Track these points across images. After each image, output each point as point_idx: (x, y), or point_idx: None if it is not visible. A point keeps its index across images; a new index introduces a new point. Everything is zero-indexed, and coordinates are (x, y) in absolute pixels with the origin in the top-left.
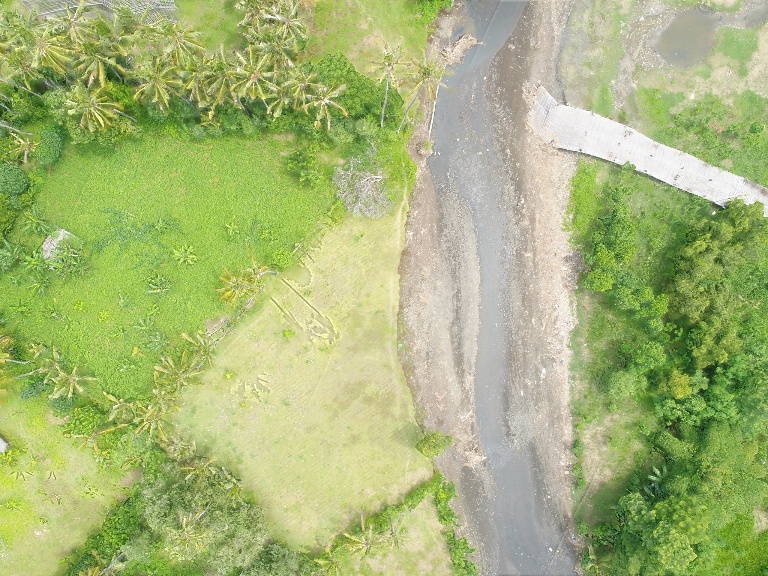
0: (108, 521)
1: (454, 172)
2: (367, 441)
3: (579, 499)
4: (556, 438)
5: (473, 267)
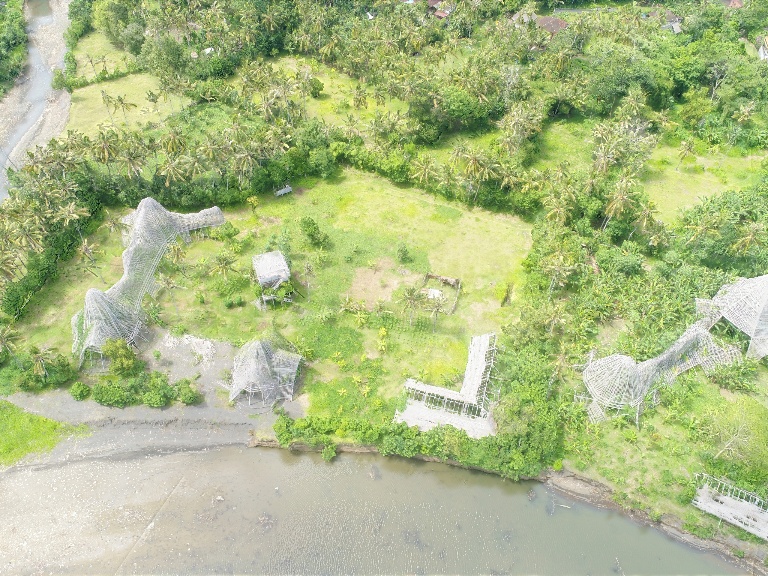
0: (219, 67)
1: (3, 184)
2: (99, 98)
3: (7, 89)
4: (7, 105)
5: (14, 153)
